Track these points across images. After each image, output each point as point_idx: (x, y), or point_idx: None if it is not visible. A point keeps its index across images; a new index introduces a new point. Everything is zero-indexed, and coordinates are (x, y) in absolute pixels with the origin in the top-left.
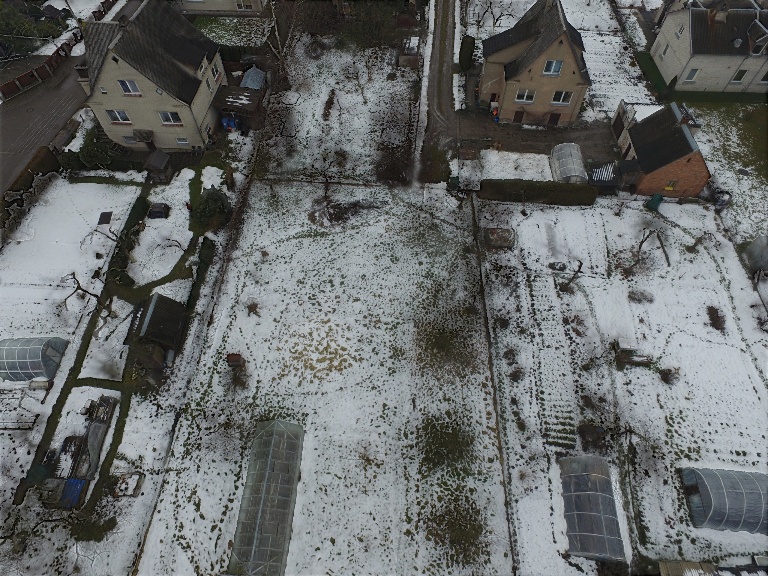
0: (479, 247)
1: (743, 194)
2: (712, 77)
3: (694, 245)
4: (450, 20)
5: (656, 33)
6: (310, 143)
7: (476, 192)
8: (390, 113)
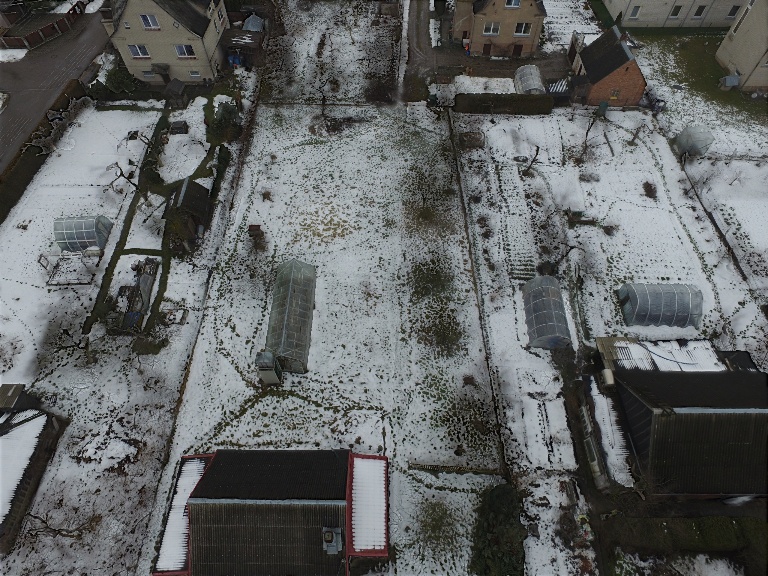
0: (455, 147)
1: (677, 103)
2: (653, 13)
3: (633, 138)
4: None
5: None
6: (307, 75)
7: (452, 107)
8: (375, 51)
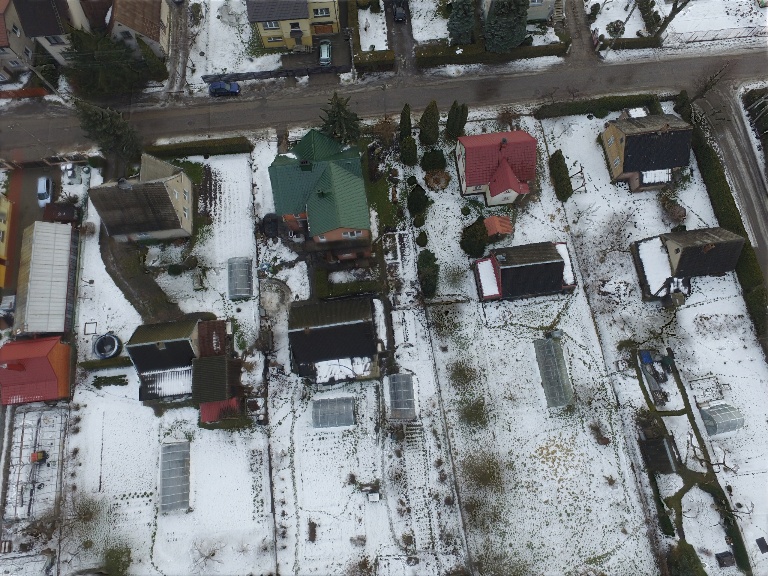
0: (471, 571)
1: None
2: None
3: None
4: None
5: None
6: None
7: None
8: None
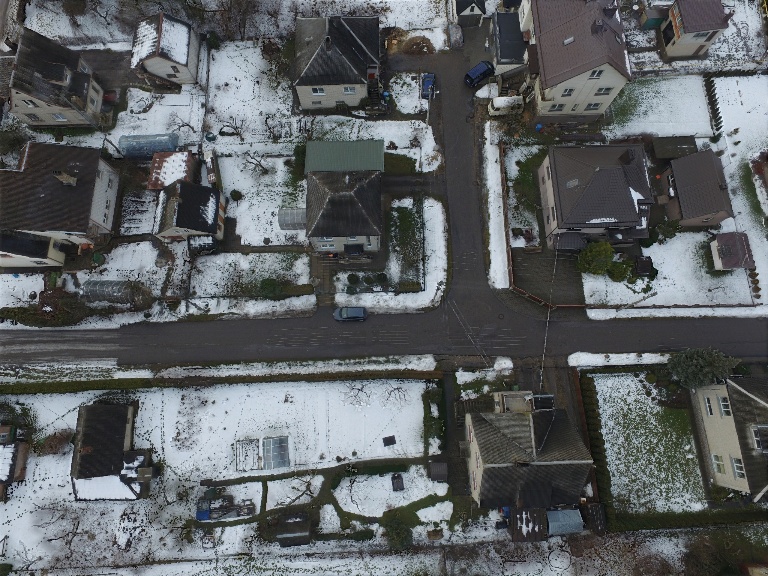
0: None
1: None
2: None
3: None
4: None
5: None
6: None
7: None
8: None
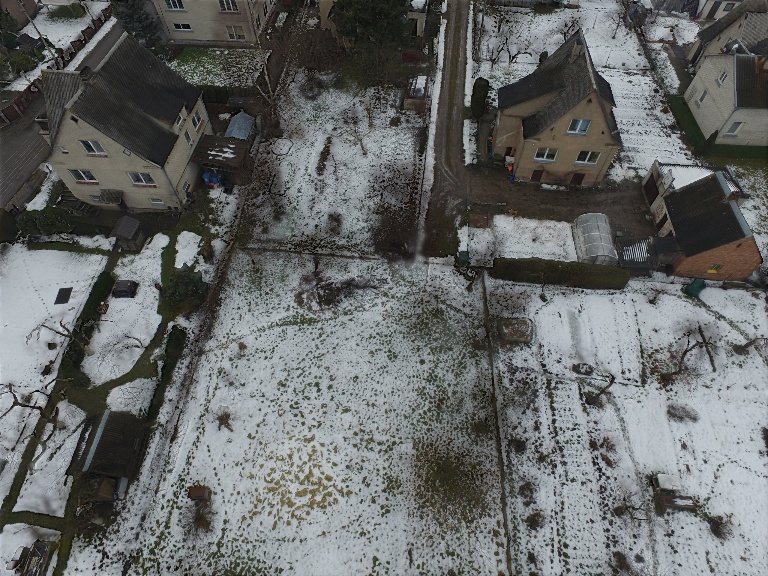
0: (491, 341)
1: None
2: (757, 131)
3: (744, 347)
4: (461, 54)
5: (690, 73)
6: (301, 204)
7: (488, 270)
8: (392, 167)
